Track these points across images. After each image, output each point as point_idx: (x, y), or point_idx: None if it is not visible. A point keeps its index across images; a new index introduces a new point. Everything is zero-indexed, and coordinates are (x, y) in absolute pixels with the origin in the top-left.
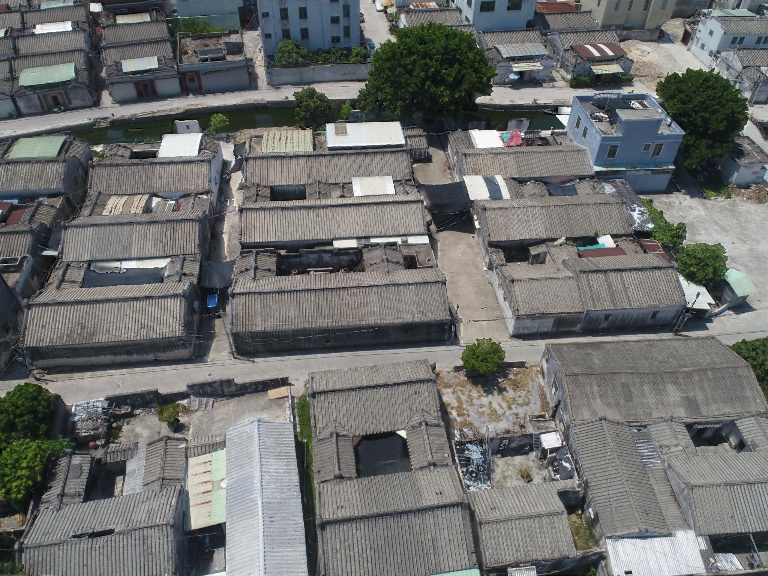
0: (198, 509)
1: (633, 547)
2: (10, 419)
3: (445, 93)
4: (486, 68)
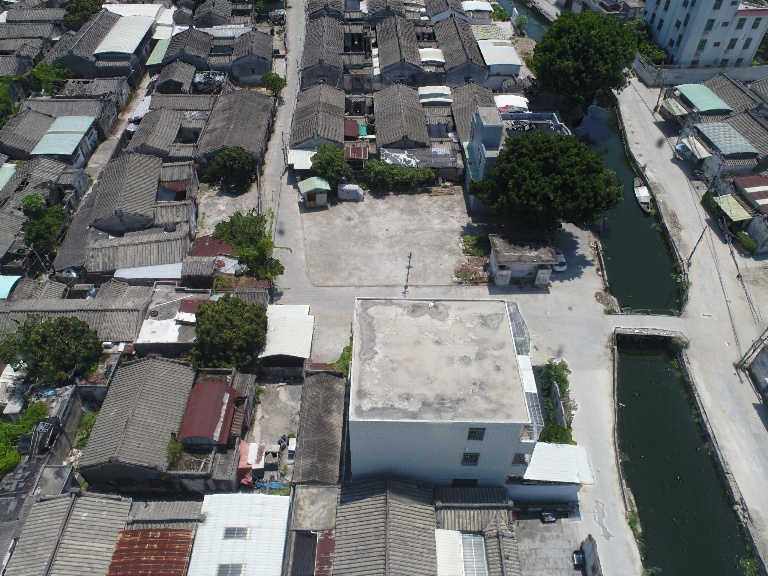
0: (221, 26)
1: None
2: None
3: (536, 57)
4: (596, 77)
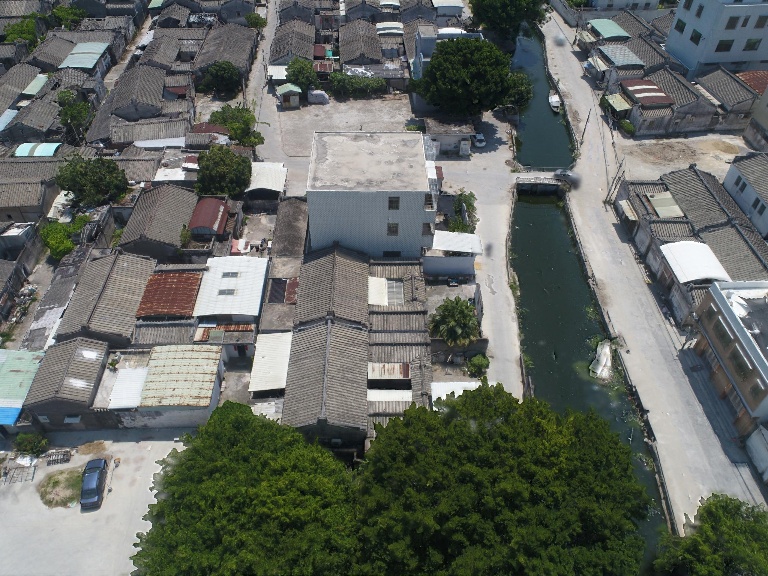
0: None
1: None
2: None
3: None
4: (519, 9)
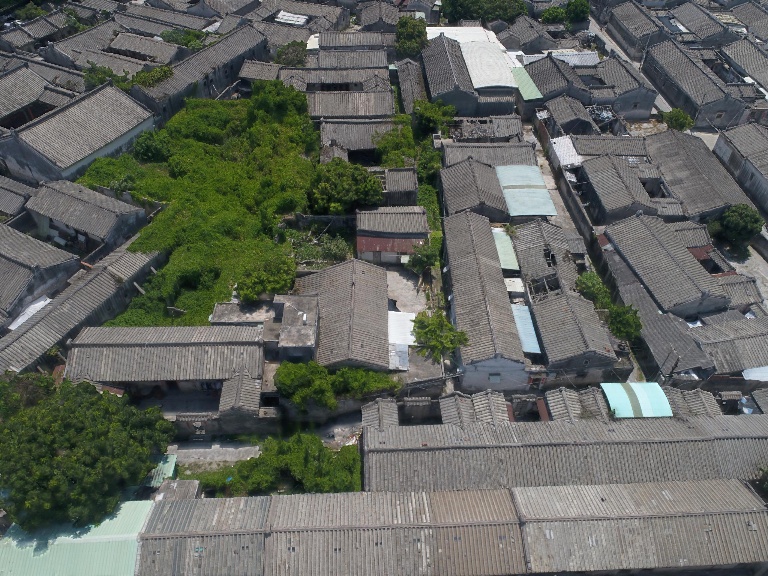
0: None
1: (568, 143)
2: None
3: None
4: None
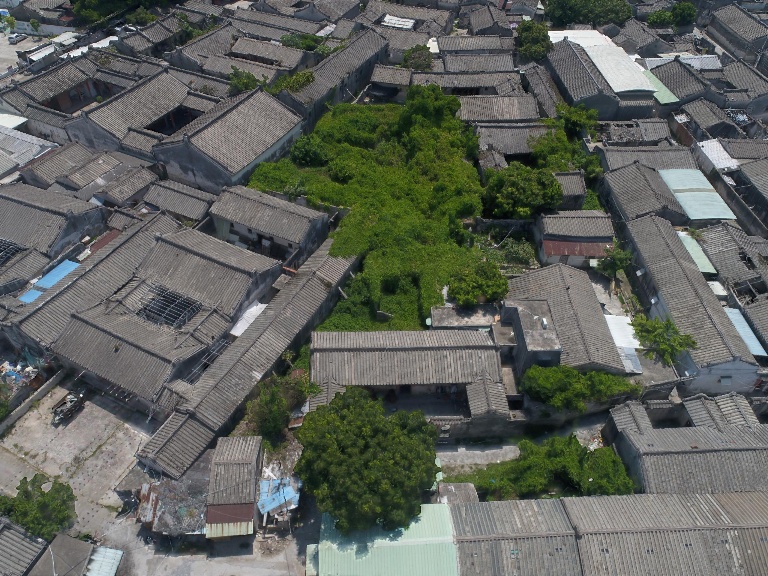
0: None
1: None
2: (677, 8)
3: None
4: None
